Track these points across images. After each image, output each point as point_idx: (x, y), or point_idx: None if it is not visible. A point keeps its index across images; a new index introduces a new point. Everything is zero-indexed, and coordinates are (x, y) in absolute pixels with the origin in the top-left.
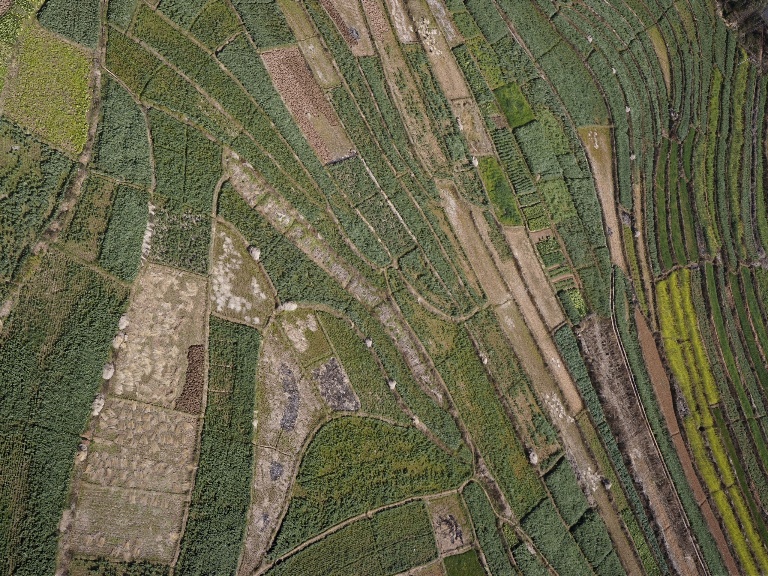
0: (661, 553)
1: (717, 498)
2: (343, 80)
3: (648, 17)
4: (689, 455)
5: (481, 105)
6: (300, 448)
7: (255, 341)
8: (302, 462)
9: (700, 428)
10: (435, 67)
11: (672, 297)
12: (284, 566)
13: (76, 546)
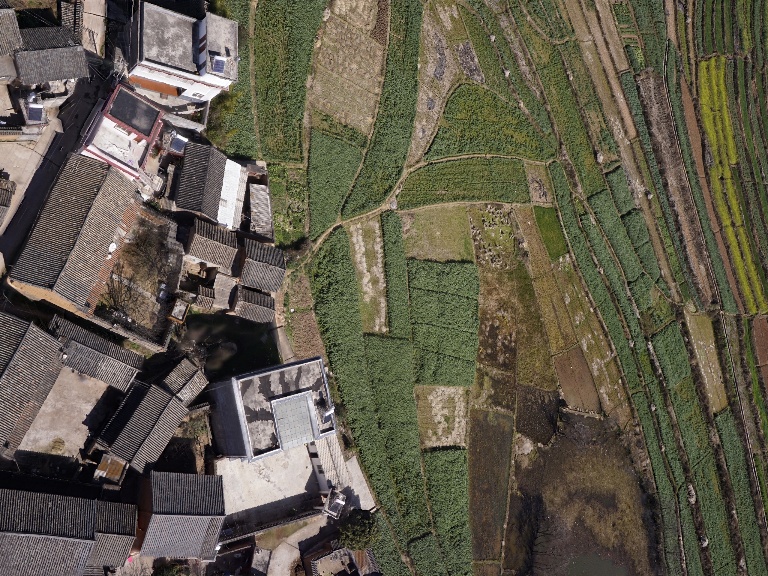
0: (683, 256)
1: (728, 231)
2: None
3: None
4: (710, 195)
5: None
6: (446, 95)
7: (420, 9)
8: (447, 104)
9: (721, 178)
10: None
11: (710, 76)
12: (435, 167)
13: (314, 102)
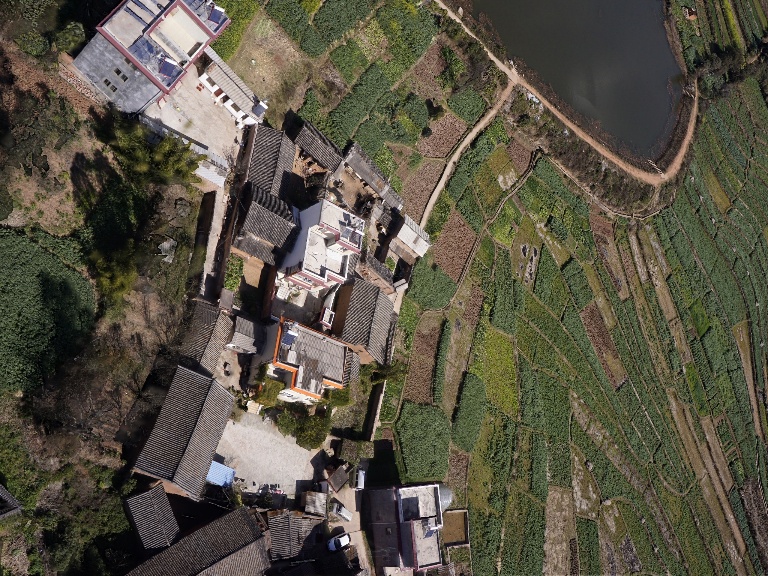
0: None
1: None
2: (618, 322)
3: (763, 220)
4: None
5: (683, 322)
6: None
7: (596, 531)
8: None
9: None
10: (659, 297)
11: None
12: None
13: None
